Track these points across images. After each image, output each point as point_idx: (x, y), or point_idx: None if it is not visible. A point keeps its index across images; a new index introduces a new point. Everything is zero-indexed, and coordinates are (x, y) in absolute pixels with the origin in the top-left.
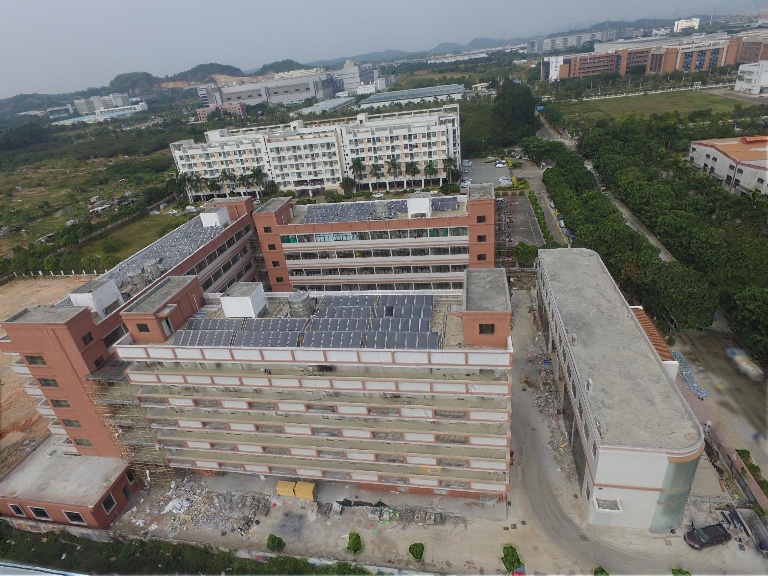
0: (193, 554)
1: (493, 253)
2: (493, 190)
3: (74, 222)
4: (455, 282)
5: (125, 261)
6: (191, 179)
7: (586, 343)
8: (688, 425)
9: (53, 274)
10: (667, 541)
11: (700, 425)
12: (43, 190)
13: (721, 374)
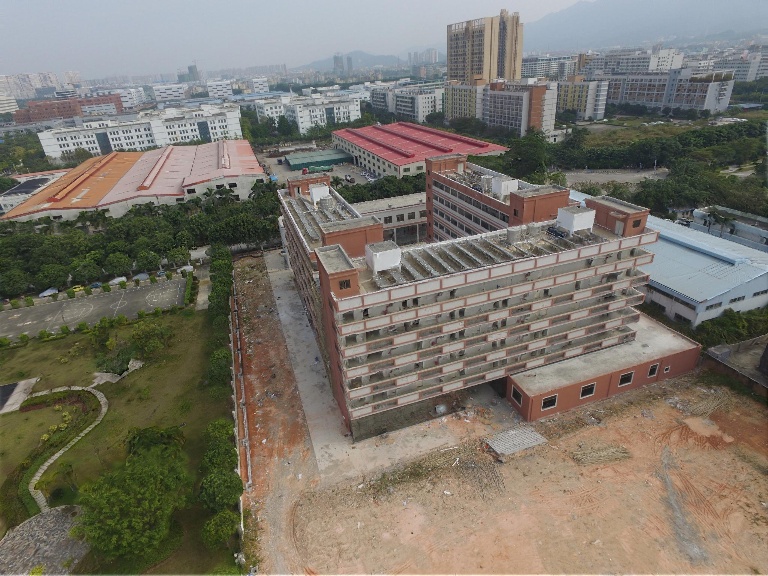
0: None
1: None
2: None
3: None
4: None
5: (523, 259)
6: None
7: None
8: (425, 194)
9: None
10: None
11: None
12: None
13: None
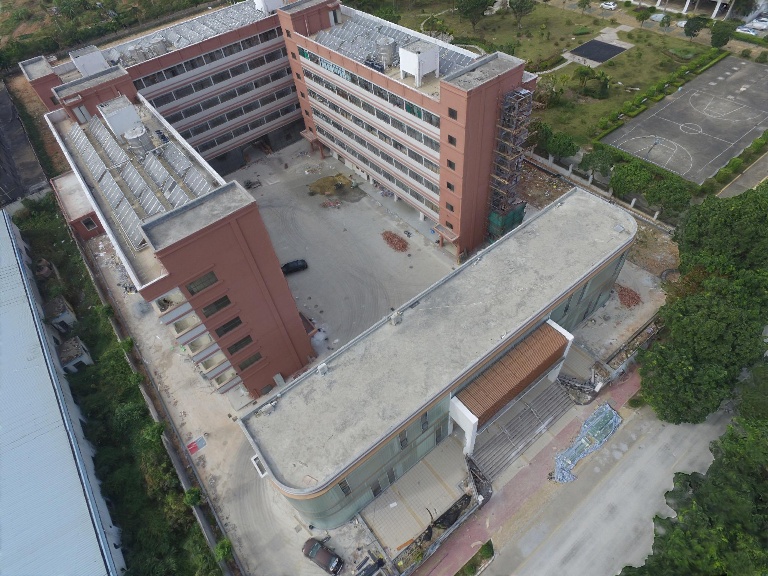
0: (87, 285)
1: (462, 166)
2: (497, 75)
3: None
4: (427, 180)
5: None
6: None
7: (406, 330)
8: (327, 472)
9: None
10: (299, 527)
11: (325, 481)
12: None
13: (627, 478)
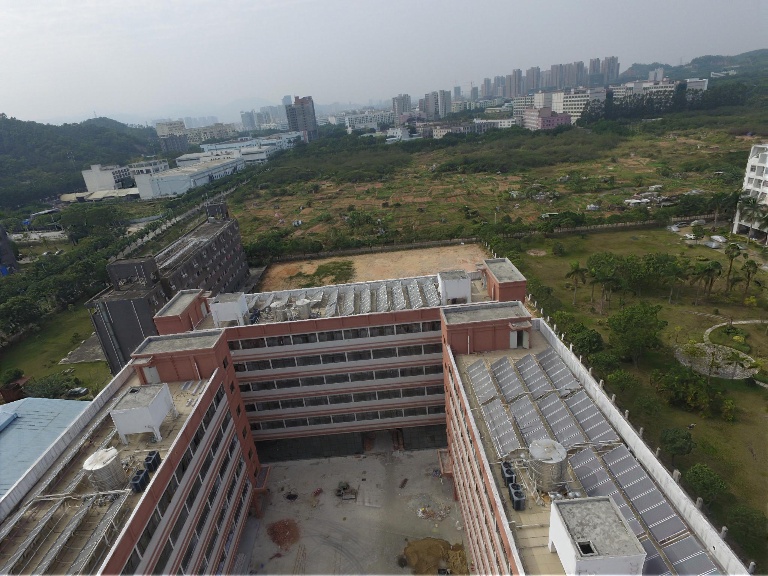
0: None
1: None
2: None
3: (594, 208)
4: None
5: (334, 286)
6: (749, 201)
7: None
8: None
9: (493, 253)
10: None
11: None
12: (644, 162)
13: None
